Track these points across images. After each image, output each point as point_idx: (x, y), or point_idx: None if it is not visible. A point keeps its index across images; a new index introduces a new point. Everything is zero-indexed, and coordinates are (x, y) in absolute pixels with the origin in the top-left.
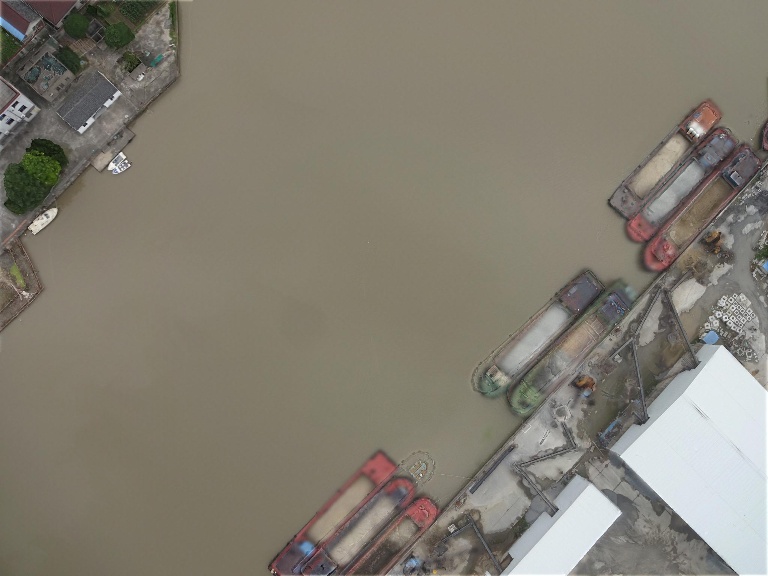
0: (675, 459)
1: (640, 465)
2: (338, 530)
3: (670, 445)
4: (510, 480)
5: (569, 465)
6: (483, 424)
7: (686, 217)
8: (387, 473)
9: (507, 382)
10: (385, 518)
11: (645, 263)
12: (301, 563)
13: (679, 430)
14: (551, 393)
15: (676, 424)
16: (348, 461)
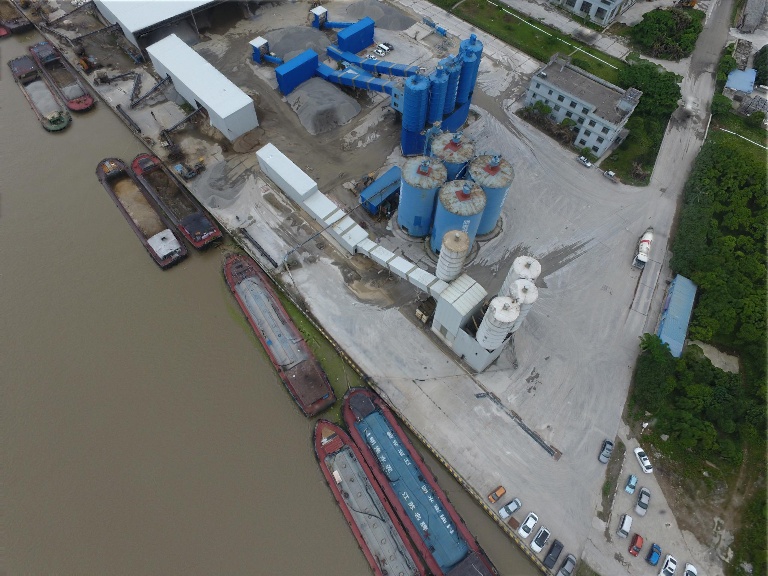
0: (146, 7)
1: (144, 24)
2: (139, 230)
3: (134, 8)
4: (146, 112)
5: (151, 80)
6: (96, 128)
7: (5, 17)
8: (103, 191)
9: (69, 112)
10: (143, 194)
11: (29, 40)
12: (157, 260)
13: (125, 3)
14: (92, 88)
15: (119, 4)
16: (76, 218)
